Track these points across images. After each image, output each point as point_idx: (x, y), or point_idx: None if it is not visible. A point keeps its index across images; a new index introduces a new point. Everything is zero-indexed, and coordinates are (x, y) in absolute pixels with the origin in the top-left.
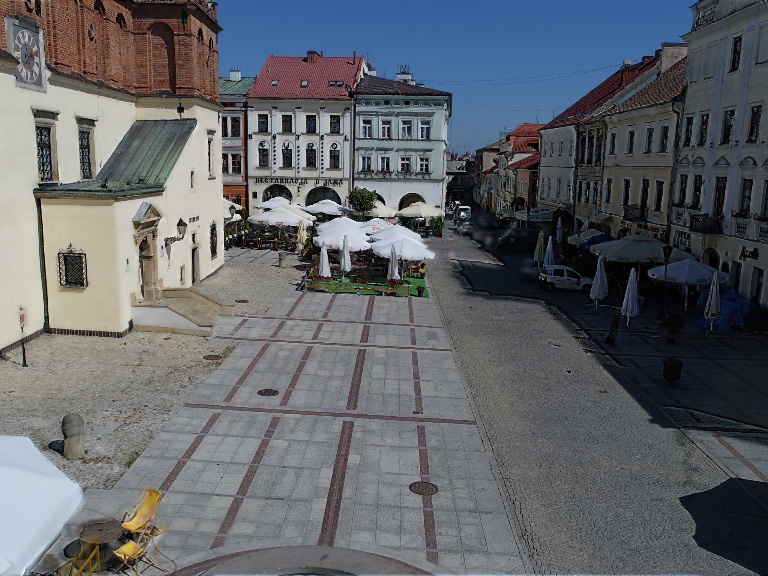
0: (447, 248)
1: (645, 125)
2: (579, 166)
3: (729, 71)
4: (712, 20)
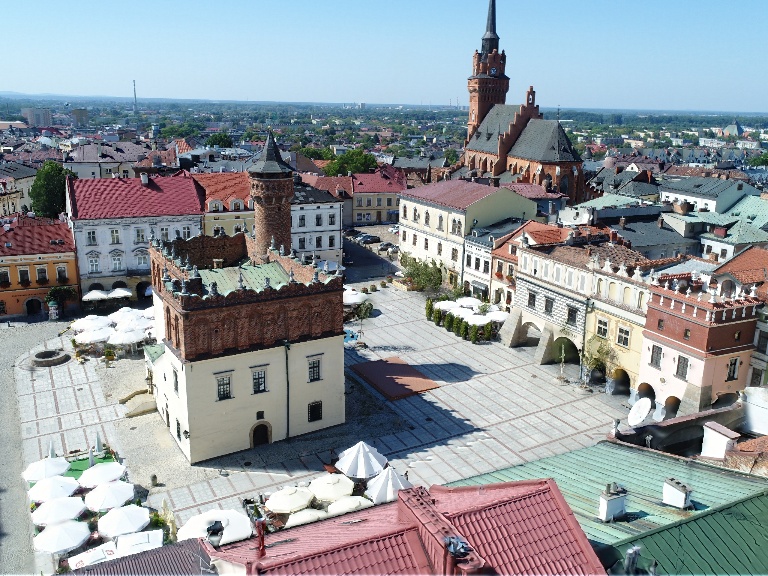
0: None
1: None
2: None
3: None
4: None
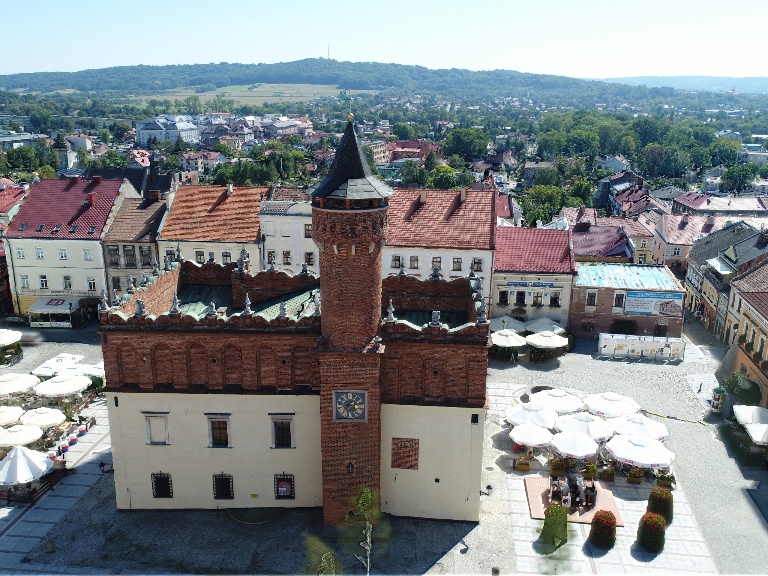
0: (94, 354)
1: (220, 250)
2: (111, 268)
3: (305, 237)
4: (281, 212)
